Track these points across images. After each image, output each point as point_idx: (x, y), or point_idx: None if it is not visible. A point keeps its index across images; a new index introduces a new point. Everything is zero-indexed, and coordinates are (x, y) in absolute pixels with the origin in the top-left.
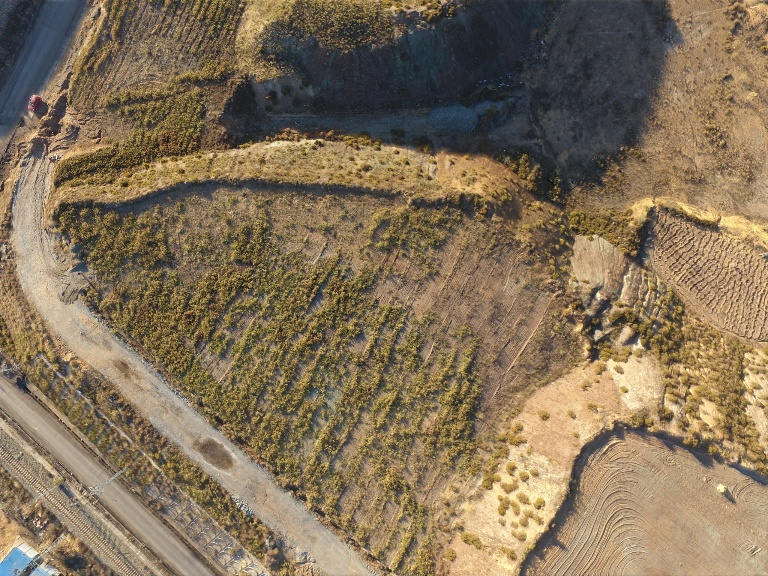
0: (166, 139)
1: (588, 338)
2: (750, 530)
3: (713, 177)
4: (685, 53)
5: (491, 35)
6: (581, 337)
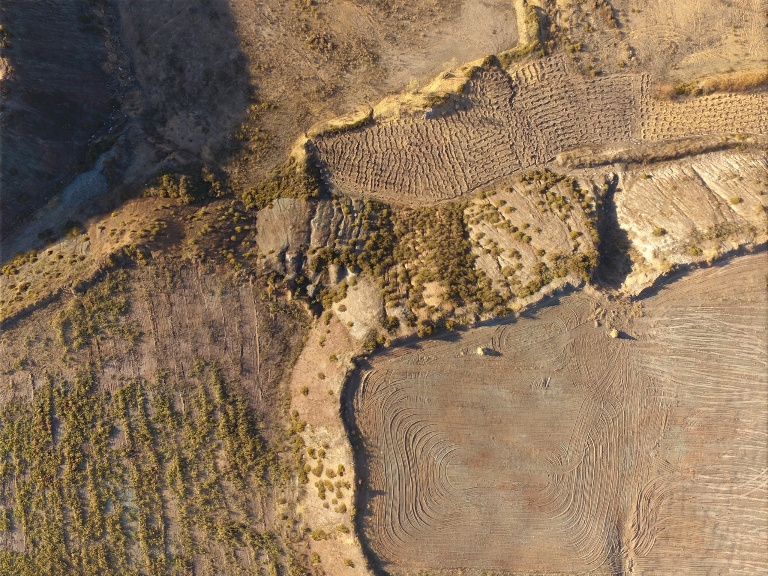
0: None
1: (302, 299)
2: (530, 368)
3: (342, 80)
4: None
5: (58, 98)
6: (296, 302)
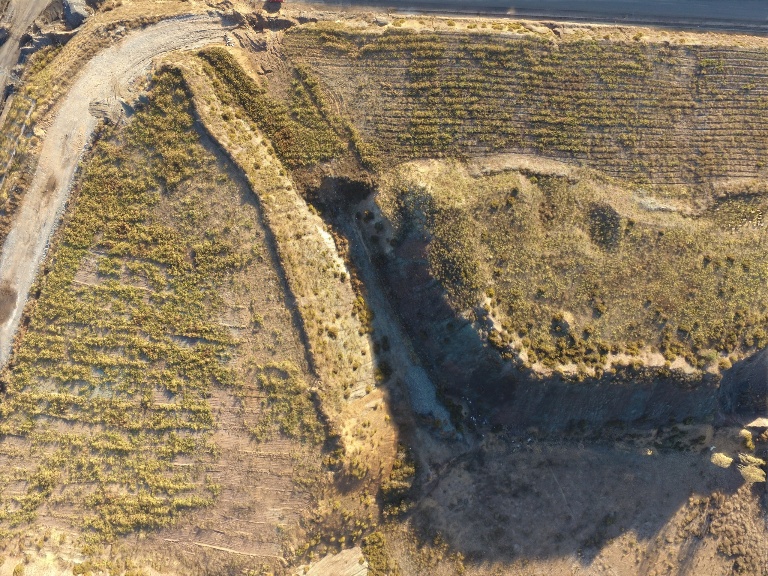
0: (287, 136)
1: None
2: None
3: None
4: (574, 575)
5: (508, 395)
6: None
